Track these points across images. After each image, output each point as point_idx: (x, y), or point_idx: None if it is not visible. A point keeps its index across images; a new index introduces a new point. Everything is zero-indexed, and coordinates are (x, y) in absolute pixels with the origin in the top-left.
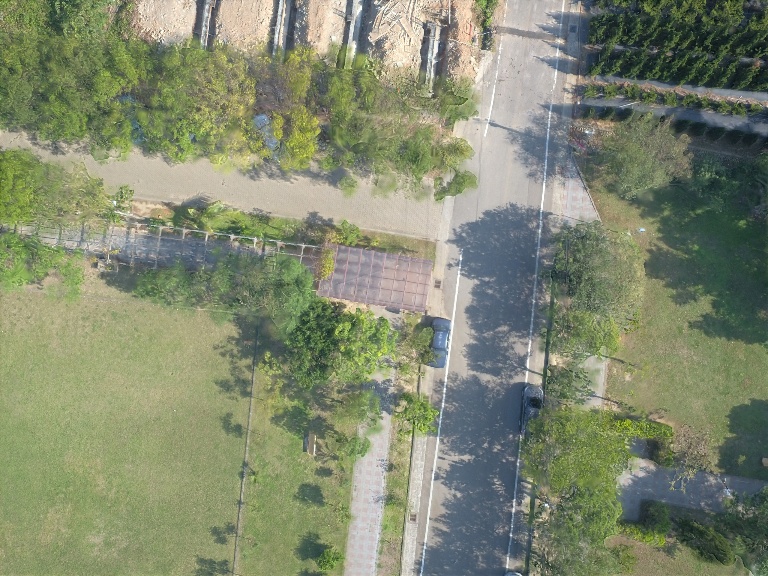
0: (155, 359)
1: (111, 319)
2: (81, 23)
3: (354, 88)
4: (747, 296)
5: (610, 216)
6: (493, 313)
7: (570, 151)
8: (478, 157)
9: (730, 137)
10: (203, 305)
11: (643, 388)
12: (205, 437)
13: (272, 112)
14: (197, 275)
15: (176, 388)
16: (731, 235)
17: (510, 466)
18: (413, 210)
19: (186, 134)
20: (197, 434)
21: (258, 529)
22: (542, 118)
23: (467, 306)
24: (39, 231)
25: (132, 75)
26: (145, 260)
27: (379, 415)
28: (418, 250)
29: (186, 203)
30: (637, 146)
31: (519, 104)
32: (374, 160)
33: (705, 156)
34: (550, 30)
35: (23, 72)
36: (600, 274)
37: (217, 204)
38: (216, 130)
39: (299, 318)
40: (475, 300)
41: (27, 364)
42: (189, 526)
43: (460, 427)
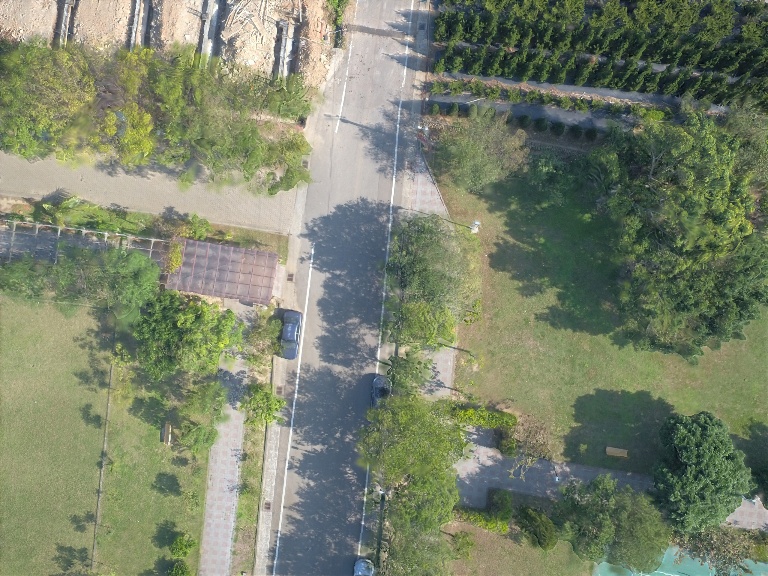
0: (17, 351)
1: None
2: None
3: (179, 85)
4: (592, 288)
5: (458, 210)
6: (344, 306)
7: (419, 146)
8: (329, 153)
9: (572, 132)
10: (62, 298)
11: (490, 379)
12: (65, 428)
13: None
14: (53, 269)
15: (37, 380)
16: (576, 228)
17: (362, 455)
18: (266, 205)
19: (26, 131)
20: (57, 425)
21: (117, 517)
22: (391, 114)
23: (319, 299)
24: None
25: None
26: (6, 255)
27: (233, 406)
28: (271, 244)
29: (46, 199)
30: (465, 141)
31: (369, 101)
32: None
33: (544, 151)
34: (399, 28)
35: None
36: (427, 266)
37: (72, 200)
38: (55, 127)
39: (144, 310)
40: (327, 293)
41: None
42: (50, 515)
43: (313, 417)
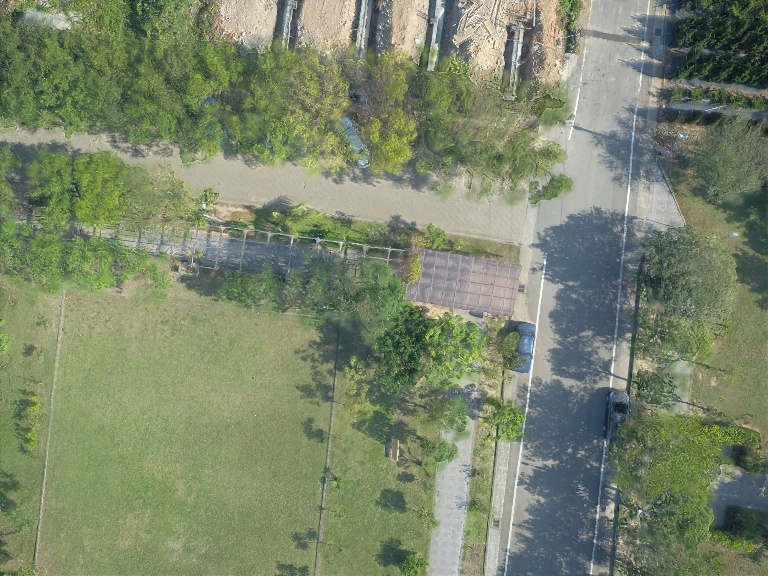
0: (235, 363)
1: (191, 323)
2: (165, 25)
3: (455, 91)
4: None
5: (696, 220)
6: (577, 317)
7: (655, 155)
8: None
9: None
10: (284, 309)
11: (729, 393)
12: (286, 442)
13: (357, 115)
14: (280, 279)
15: (256, 392)
16: None
17: (594, 472)
18: (497, 214)
19: (279, 137)
20: (278, 439)
21: (339, 535)
22: (627, 121)
23: (551, 310)
24: (118, 234)
25: (223, 77)
26: (226, 263)
27: (462, 420)
28: (502, 254)
29: (267, 206)
30: (734, 150)
31: (604, 107)
32: (459, 163)
33: None
34: (635, 33)
35: (112, 74)
36: (697, 279)
37: (301, 207)
38: (309, 133)
39: (388, 322)
40: (559, 304)
41: (105, 368)
42: (270, 532)
43: (544, 432)
